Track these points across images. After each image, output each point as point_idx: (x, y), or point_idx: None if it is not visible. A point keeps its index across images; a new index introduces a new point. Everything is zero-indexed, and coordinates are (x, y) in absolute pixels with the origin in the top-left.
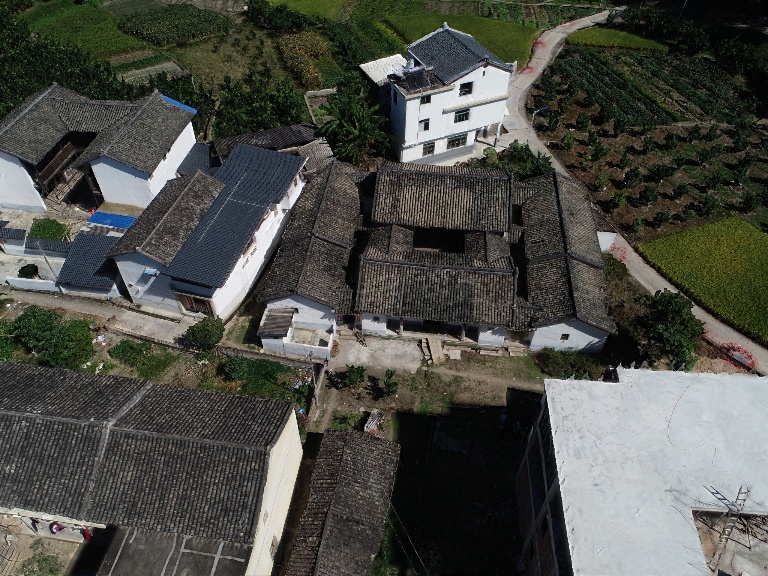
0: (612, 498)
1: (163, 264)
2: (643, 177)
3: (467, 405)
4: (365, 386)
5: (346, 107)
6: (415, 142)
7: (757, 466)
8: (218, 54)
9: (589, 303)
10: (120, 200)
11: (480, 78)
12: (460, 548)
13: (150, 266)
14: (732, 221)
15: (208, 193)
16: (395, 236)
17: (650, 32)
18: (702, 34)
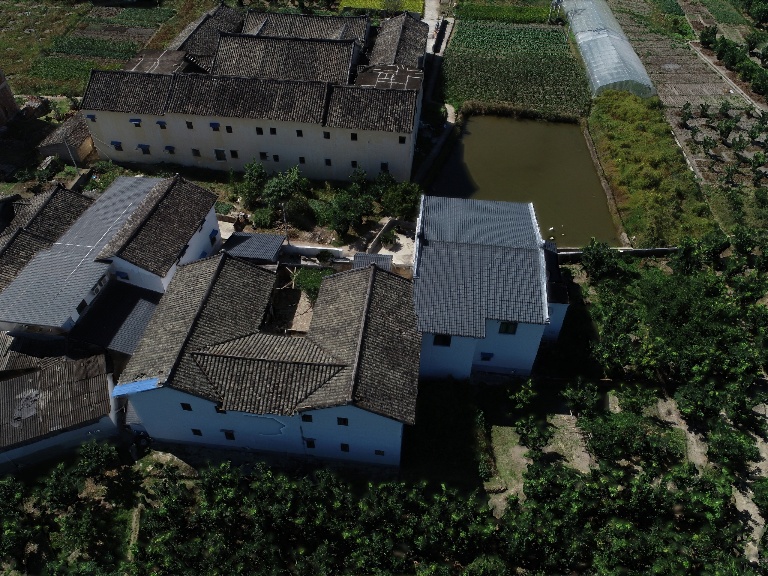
0: None
1: None
2: None
3: None
4: None
5: None
6: None
7: None
8: None
9: None
10: None
11: None
12: None
13: None
14: None
15: None
16: None
17: None
18: None
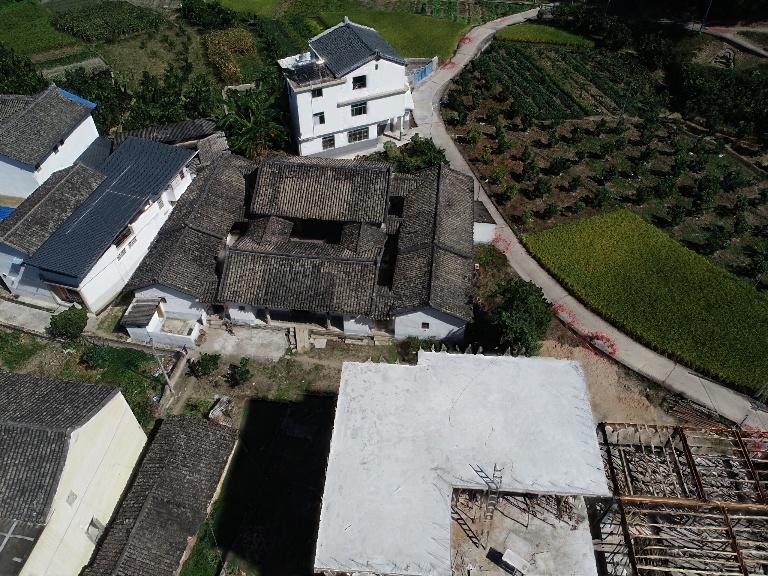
0: (376, 476)
1: (26, 254)
2: (544, 170)
3: (322, 393)
4: (224, 374)
5: (242, 101)
6: (312, 135)
7: (528, 445)
8: (145, 50)
9: (448, 292)
10: (11, 193)
11: (373, 72)
12: (287, 531)
13: (17, 256)
14: (621, 213)
15: (87, 185)
16: (272, 227)
17: (577, 28)
18: (625, 29)
